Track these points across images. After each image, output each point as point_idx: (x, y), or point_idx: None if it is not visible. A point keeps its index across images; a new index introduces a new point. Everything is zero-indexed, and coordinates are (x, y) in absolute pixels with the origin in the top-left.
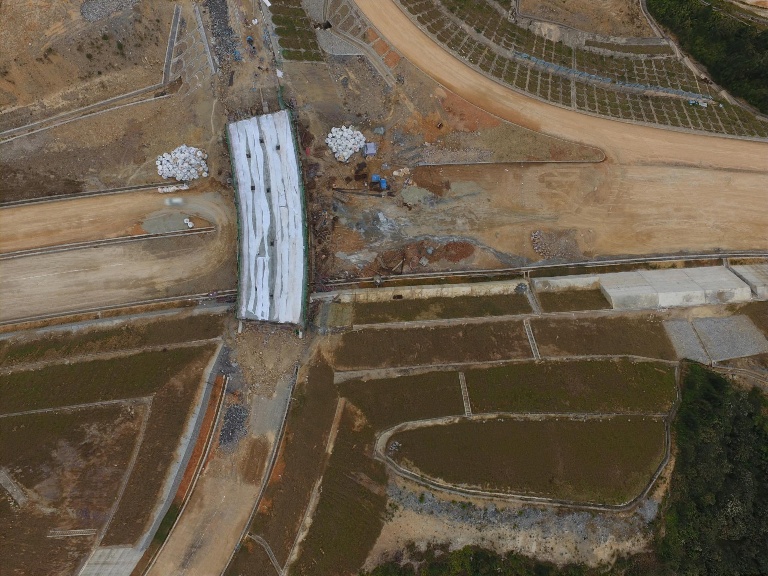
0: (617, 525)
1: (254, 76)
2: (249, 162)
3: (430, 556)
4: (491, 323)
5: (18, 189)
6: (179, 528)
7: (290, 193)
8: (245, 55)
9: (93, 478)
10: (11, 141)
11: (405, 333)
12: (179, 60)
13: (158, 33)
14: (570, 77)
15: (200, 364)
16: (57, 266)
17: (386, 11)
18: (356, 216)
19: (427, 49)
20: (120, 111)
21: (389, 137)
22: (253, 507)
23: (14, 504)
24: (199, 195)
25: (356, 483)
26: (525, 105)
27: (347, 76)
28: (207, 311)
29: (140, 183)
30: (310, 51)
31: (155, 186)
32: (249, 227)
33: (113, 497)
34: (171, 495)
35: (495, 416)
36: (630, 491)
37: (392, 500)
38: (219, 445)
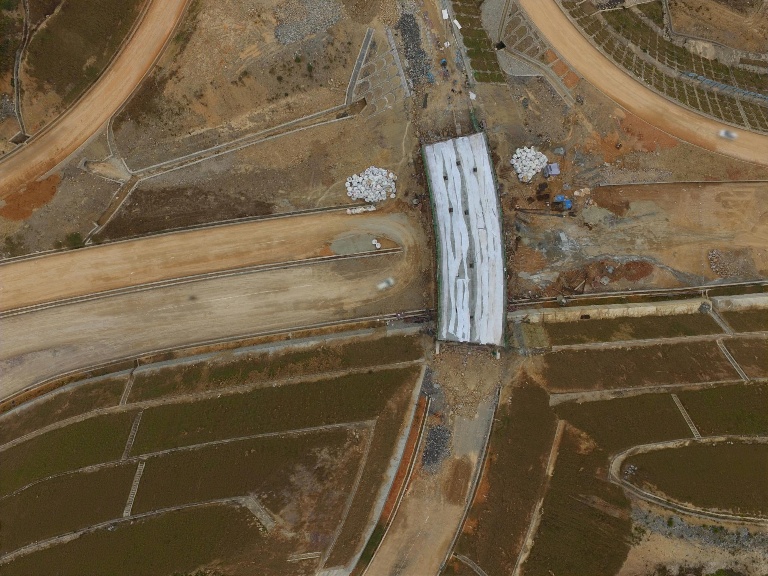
0: None
1: (447, 98)
2: (446, 184)
3: None
4: (685, 343)
5: (210, 211)
6: (383, 548)
7: (488, 215)
8: (438, 78)
9: (326, 502)
10: (199, 163)
11: (605, 354)
12: (365, 82)
13: (347, 55)
14: (734, 96)
15: (409, 386)
16: (248, 287)
17: (564, 32)
18: (538, 236)
19: (605, 70)
20: (305, 132)
21: (570, 157)
22: (458, 527)
23: (263, 530)
24: (385, 216)
25: (588, 506)
26: (701, 125)
27: (527, 97)
28: (400, 332)
29: (329, 204)
30: (494, 72)
31: (343, 207)
32: (448, 249)
33: (337, 520)
34: (379, 516)
35: (724, 439)
36: None
37: (638, 524)
38: (422, 466)
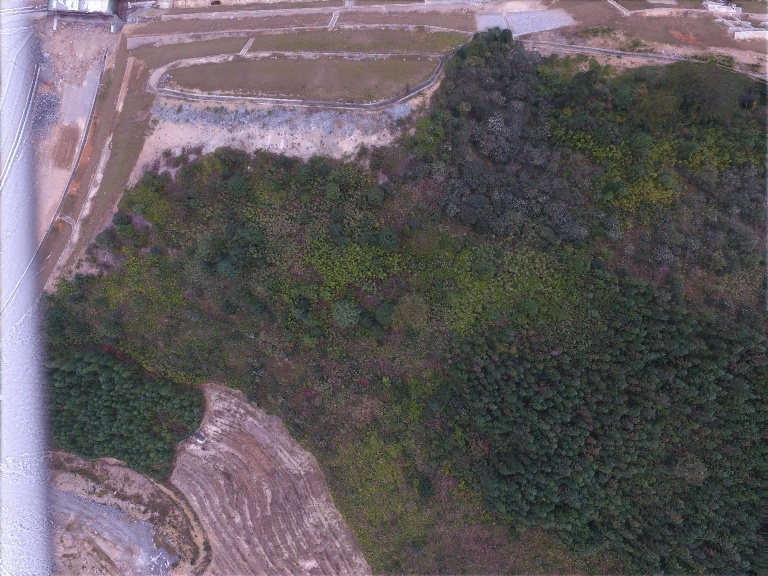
0: (363, 121)
1: None
2: None
3: (181, 155)
4: (300, 15)
5: None
6: None
7: None
8: None
9: None
10: None
11: (210, 20)
12: None
13: None
14: None
15: (6, 45)
16: None
17: None
18: None
19: None
20: None
21: None
22: (63, 190)
23: None
24: None
25: (133, 122)
26: None
27: None
28: (28, 16)
29: None
30: None
31: None
32: None
33: None
34: None
35: (269, 54)
36: (380, 92)
37: (154, 117)
38: (32, 133)
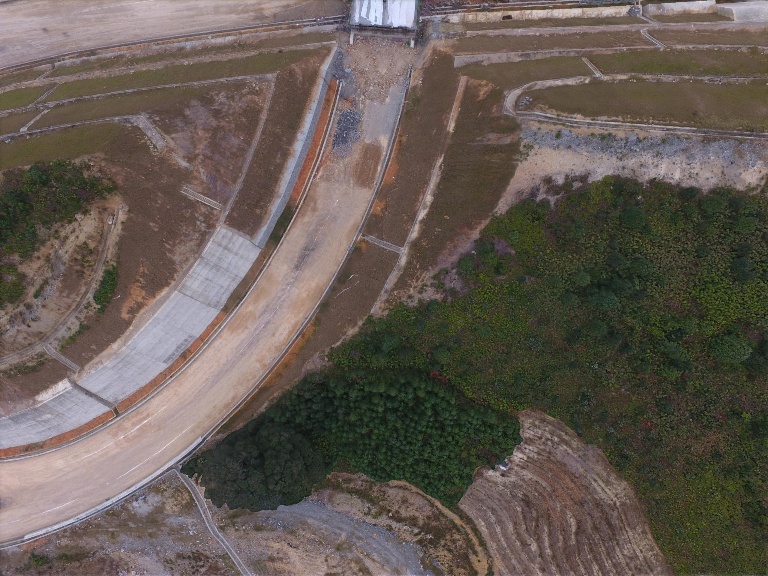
0: (766, 151)
1: None
2: None
3: (569, 183)
4: (607, 32)
5: None
6: (293, 231)
7: None
8: None
9: (222, 143)
10: None
11: (520, 36)
12: None
13: None
14: None
15: (317, 60)
16: None
17: None
18: None
19: None
20: None
21: None
22: (366, 209)
23: (153, 147)
24: None
25: (483, 145)
26: None
27: None
28: (317, 29)
29: None
30: None
31: None
32: None
33: (238, 173)
34: (287, 193)
35: (627, 77)
36: None
37: (526, 141)
38: (332, 150)
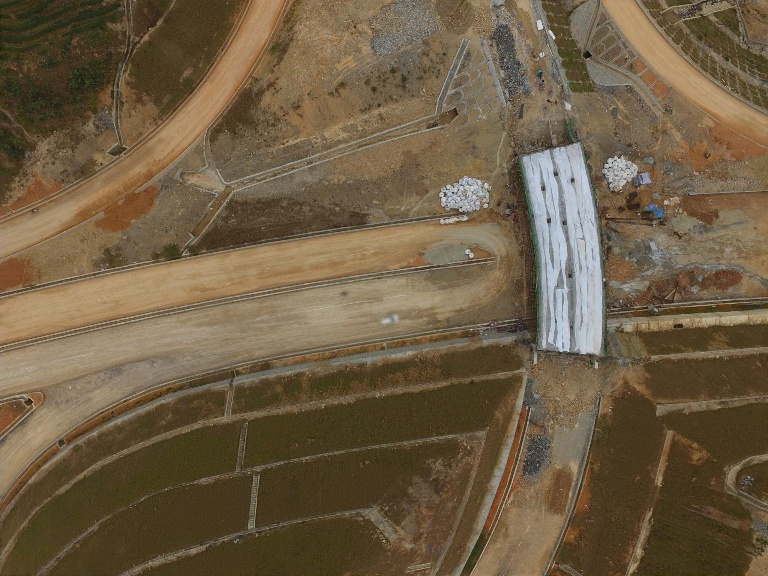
0: None
1: (543, 109)
2: (544, 195)
3: None
4: None
5: (305, 222)
6: (484, 558)
7: (586, 225)
8: (534, 88)
9: (441, 513)
10: (293, 173)
11: (704, 364)
12: (456, 92)
13: (441, 66)
14: None
15: (513, 397)
16: (342, 297)
17: (652, 41)
18: (628, 245)
19: (693, 79)
20: (396, 143)
21: (660, 167)
22: (559, 537)
23: (386, 542)
24: (478, 226)
25: (703, 516)
26: None
27: (616, 106)
28: (496, 342)
29: (423, 215)
30: (585, 82)
31: (437, 217)
32: (546, 259)
33: (449, 531)
34: None
35: None
36: None
37: (759, 535)
38: (523, 476)
